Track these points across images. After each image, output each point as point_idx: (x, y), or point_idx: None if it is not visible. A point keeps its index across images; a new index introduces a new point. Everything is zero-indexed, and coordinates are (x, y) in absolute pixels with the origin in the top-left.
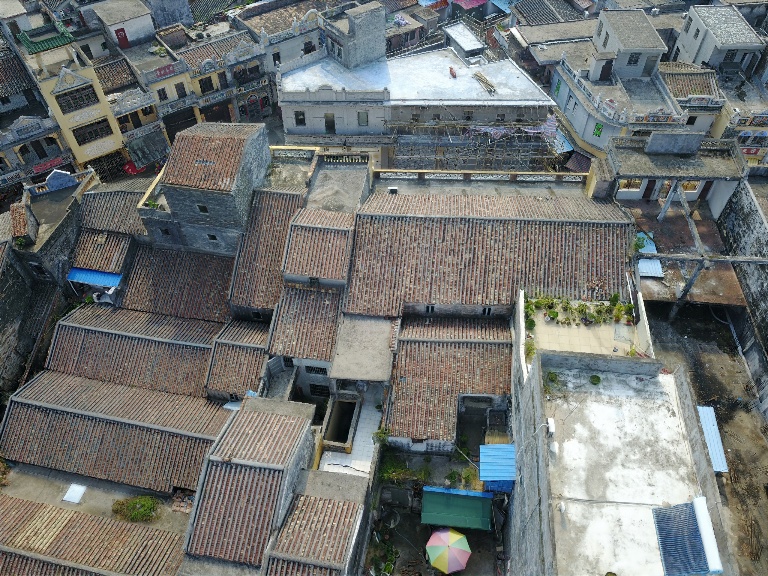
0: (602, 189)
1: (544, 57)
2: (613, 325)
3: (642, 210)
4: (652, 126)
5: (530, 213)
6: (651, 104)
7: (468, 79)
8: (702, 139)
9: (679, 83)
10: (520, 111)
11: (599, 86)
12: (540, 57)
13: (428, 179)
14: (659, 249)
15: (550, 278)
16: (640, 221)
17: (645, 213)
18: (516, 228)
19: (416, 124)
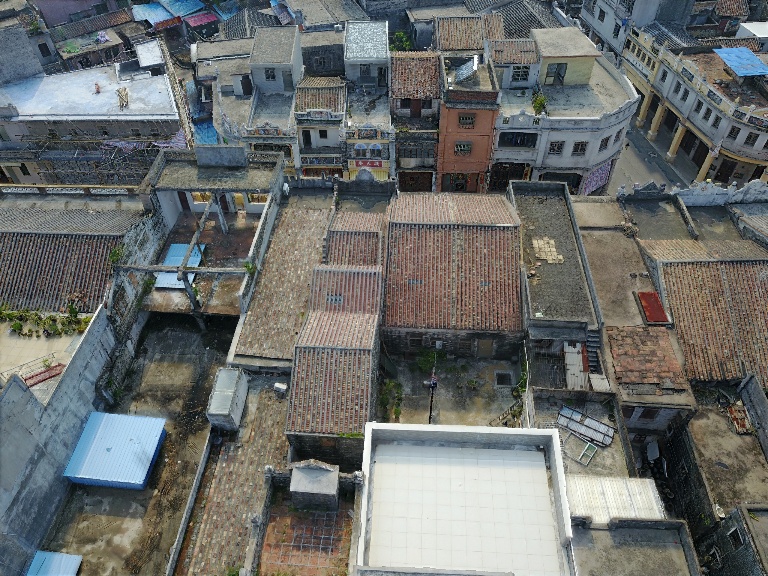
0: (149, 202)
1: (204, 72)
2: (74, 337)
3: (216, 222)
4: (263, 139)
5: (44, 226)
6: (276, 118)
7: (110, 94)
8: (243, 152)
9: (308, 97)
10: (151, 125)
11: (231, 101)
12: (199, 73)
13: (6, 193)
14: (203, 261)
15: (34, 290)
16: (207, 233)
17: (217, 225)
18: (12, 241)
19: (52, 139)
